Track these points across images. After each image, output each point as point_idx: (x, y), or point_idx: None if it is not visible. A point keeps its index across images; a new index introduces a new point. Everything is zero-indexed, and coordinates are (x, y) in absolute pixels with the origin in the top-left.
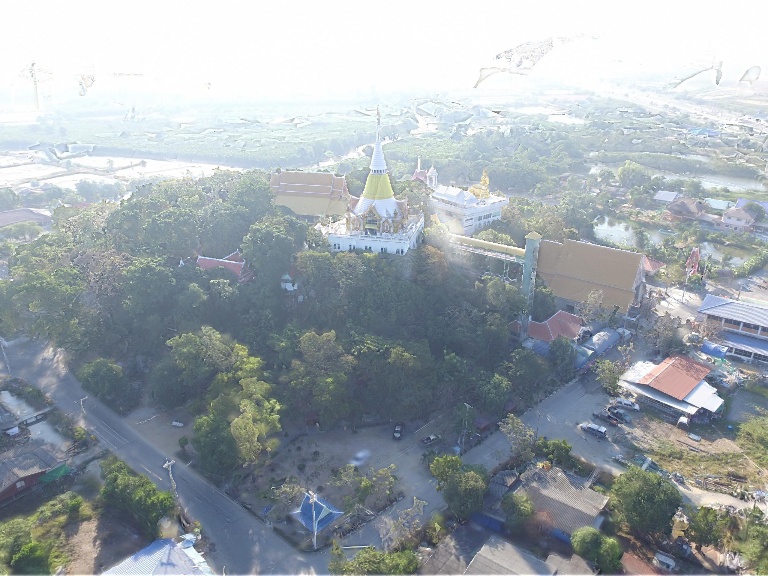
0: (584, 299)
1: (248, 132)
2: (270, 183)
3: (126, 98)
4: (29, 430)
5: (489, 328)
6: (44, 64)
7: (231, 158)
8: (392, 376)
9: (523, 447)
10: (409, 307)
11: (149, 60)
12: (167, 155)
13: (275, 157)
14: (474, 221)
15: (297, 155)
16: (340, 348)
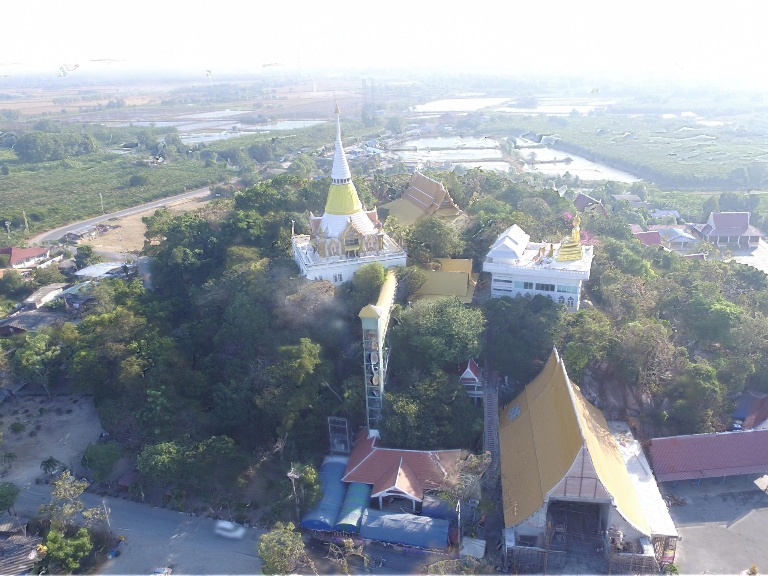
0: (509, 466)
1: (740, 143)
2: (409, 184)
3: (114, 81)
4: (88, 310)
5: (256, 399)
6: (259, 56)
7: (645, 168)
8: (115, 380)
9: (39, 511)
10: (233, 334)
11: (349, 52)
12: (599, 156)
13: (687, 174)
14: (515, 286)
15: (724, 176)
16: (125, 334)
